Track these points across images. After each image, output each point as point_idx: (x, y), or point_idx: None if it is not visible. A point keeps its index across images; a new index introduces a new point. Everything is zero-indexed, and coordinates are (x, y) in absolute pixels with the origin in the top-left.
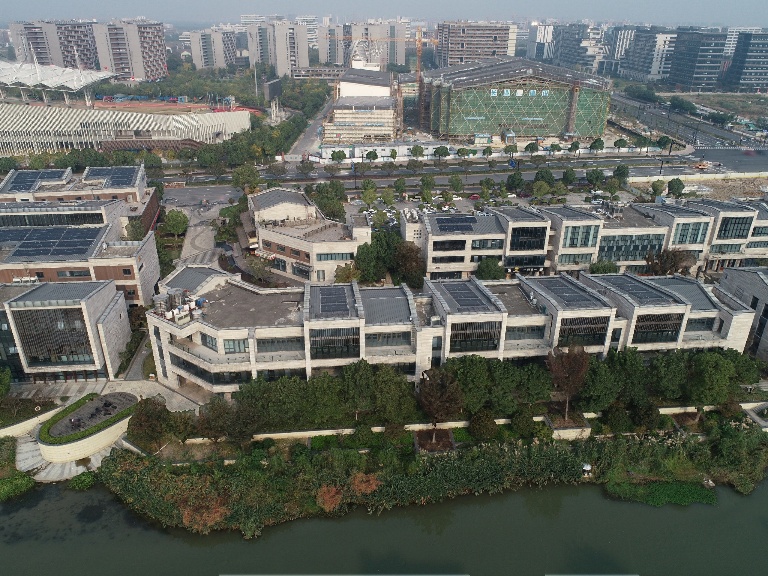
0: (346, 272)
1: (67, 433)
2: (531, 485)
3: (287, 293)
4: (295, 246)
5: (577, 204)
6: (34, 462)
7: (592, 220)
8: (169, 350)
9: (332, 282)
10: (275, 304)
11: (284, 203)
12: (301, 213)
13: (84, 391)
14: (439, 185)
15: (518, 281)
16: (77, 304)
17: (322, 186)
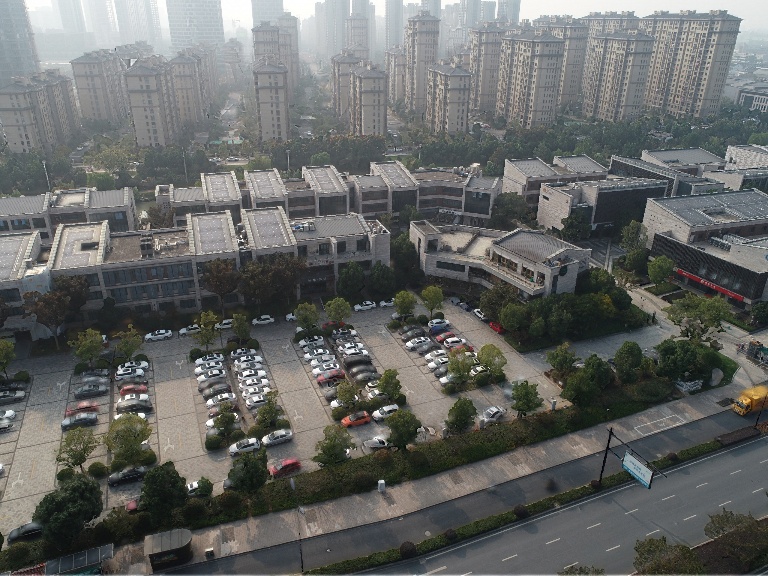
0: None
1: None
2: None
3: (426, 183)
4: None
5: (178, 255)
6: None
7: (199, 214)
8: None
9: None
10: None
11: None
12: None
13: None
14: (388, 552)
15: (288, 192)
16: None
17: (592, 357)
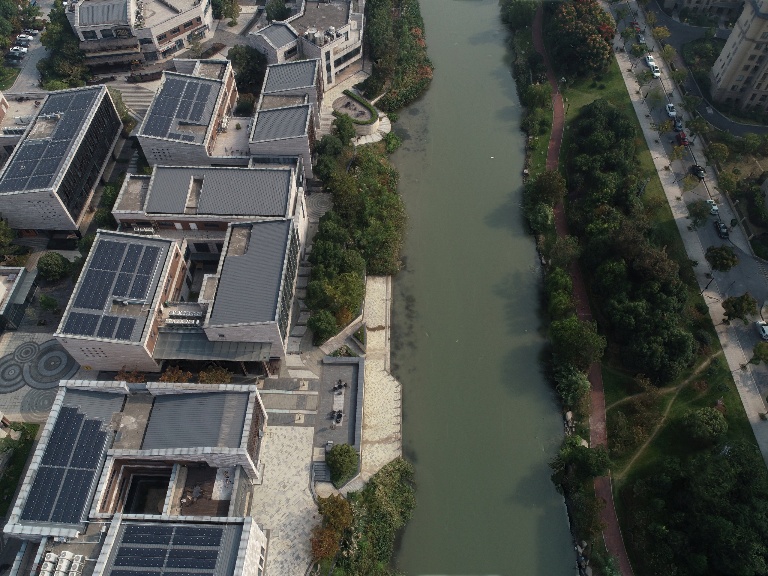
0: (237, 6)
1: (368, 116)
2: (417, 0)
3: (304, 7)
4: (187, 19)
5: None
6: (376, 136)
7: None
8: (335, 59)
9: (213, 29)
10: (319, 10)
11: (130, 2)
12: (134, 5)
13: (328, 118)
14: None
15: None
16: (318, 63)
17: (10, 6)
